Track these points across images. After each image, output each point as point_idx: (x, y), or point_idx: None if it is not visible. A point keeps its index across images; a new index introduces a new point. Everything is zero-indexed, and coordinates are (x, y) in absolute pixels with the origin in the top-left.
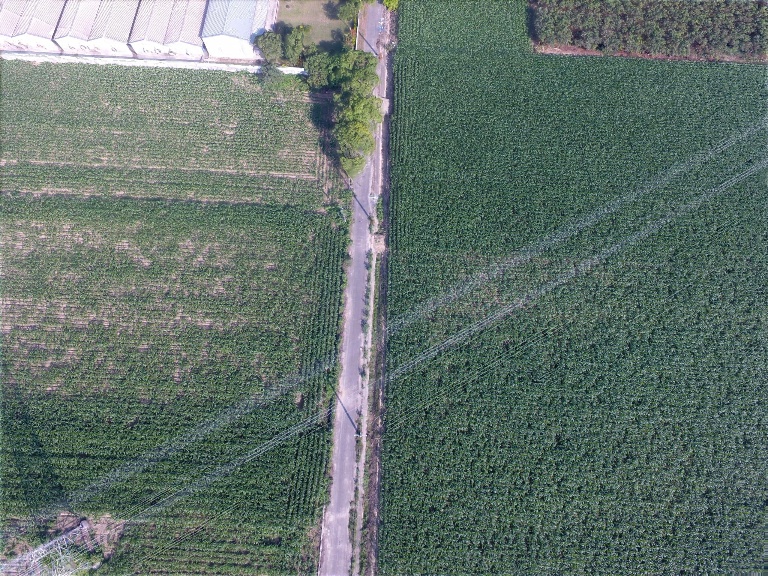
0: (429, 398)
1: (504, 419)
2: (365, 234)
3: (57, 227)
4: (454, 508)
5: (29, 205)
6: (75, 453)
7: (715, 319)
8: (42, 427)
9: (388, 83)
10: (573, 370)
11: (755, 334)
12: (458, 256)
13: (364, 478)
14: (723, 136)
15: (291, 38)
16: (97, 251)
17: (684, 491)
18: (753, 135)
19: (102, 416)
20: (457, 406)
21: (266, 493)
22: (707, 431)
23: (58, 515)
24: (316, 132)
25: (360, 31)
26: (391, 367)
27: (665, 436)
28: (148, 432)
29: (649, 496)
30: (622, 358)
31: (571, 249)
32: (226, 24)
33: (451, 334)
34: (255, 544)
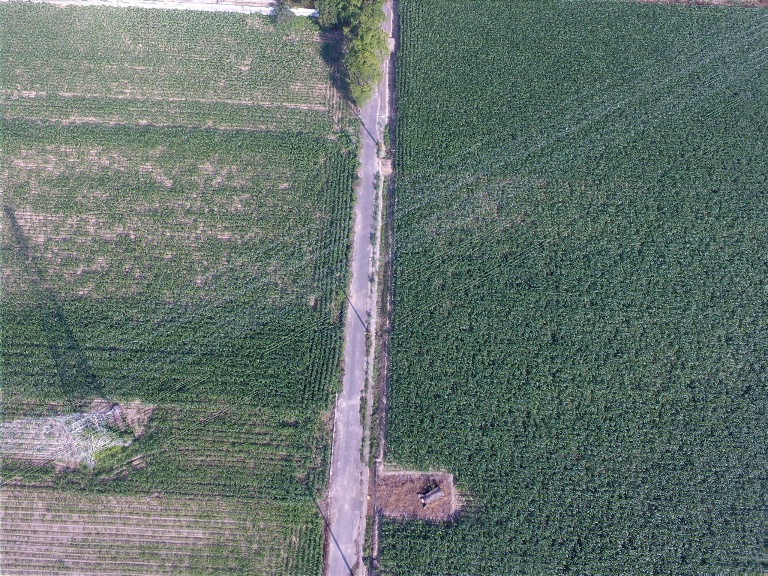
0: (433, 300)
1: (503, 319)
2: (373, 158)
3: (85, 151)
4: (457, 395)
5: (59, 131)
6: (107, 347)
7: (701, 233)
8: (76, 324)
9: (394, 25)
10: (567, 277)
11: (738, 246)
12: (460, 177)
13: (373, 371)
14: (710, 71)
15: None
16: (123, 172)
17: (670, 382)
18: (739, 70)
19: (131, 315)
20: (459, 308)
21: (283, 381)
22: (692, 330)
23: (92, 401)
24: (326, 68)
25: None
26: (398, 274)
27: (653, 334)
28: (174, 329)
29: (637, 386)
30: (613, 266)
31: (566, 171)
32: None
33: (454, 245)
34: (274, 426)
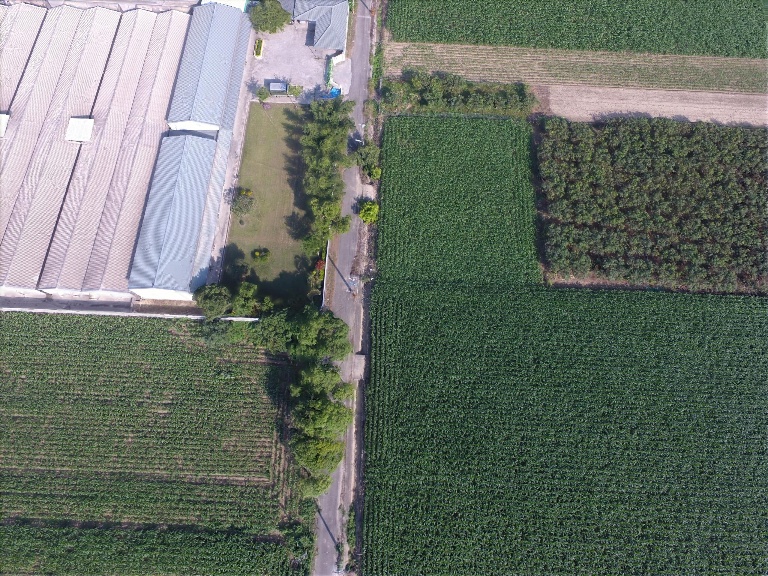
0: None
1: None
2: (331, 573)
3: None
4: None
5: None
6: None
7: None
8: None
9: (364, 328)
10: None
11: None
12: None
13: None
14: None
15: (238, 300)
16: None
17: None
18: None
19: None
20: None
21: None
22: None
23: None
24: (272, 410)
25: (330, 255)
26: None
27: None
28: None
29: None
30: None
31: None
32: (158, 272)
33: None
34: None
